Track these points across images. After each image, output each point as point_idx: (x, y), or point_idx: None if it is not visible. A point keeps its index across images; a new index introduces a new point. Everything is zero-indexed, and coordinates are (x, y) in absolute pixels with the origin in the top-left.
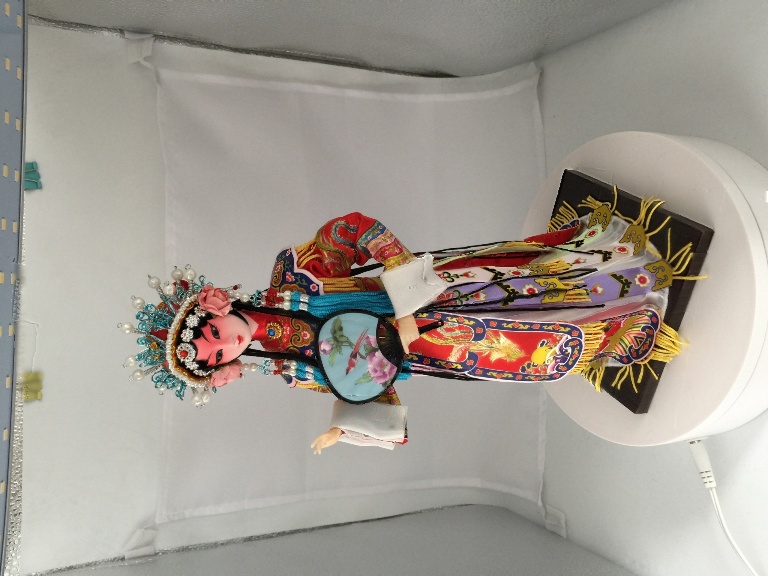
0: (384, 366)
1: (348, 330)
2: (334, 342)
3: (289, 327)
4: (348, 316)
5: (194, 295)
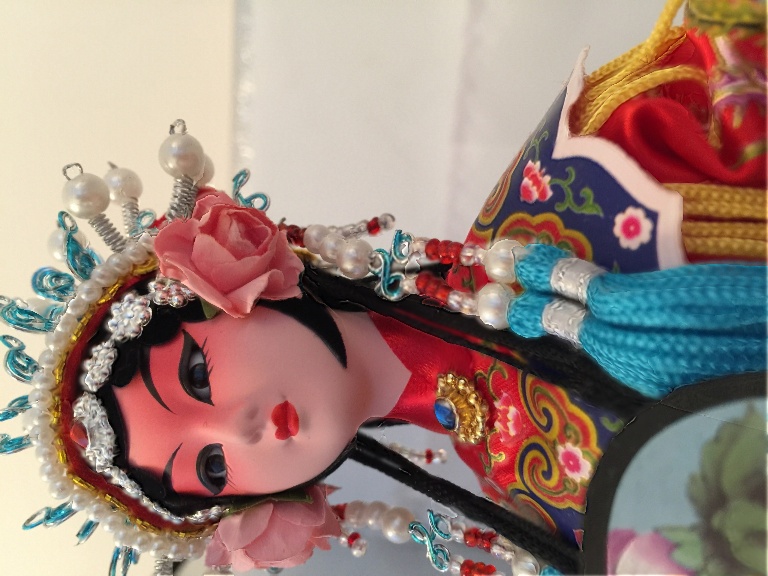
0: None
1: None
2: (706, 561)
3: (515, 406)
4: None
5: None
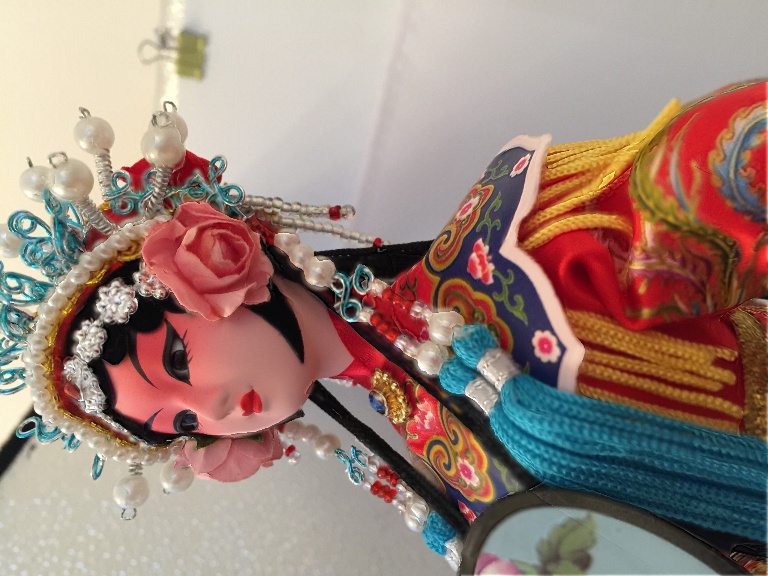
0: None
1: None
2: None
3: (432, 413)
4: (631, 535)
5: (160, 217)
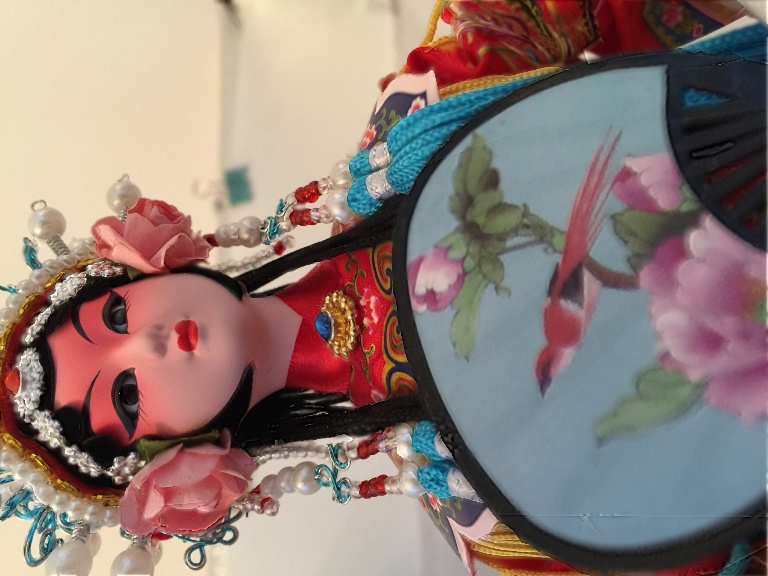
0: (767, 302)
1: (522, 174)
2: (467, 246)
3: (374, 295)
4: (516, 117)
5: None
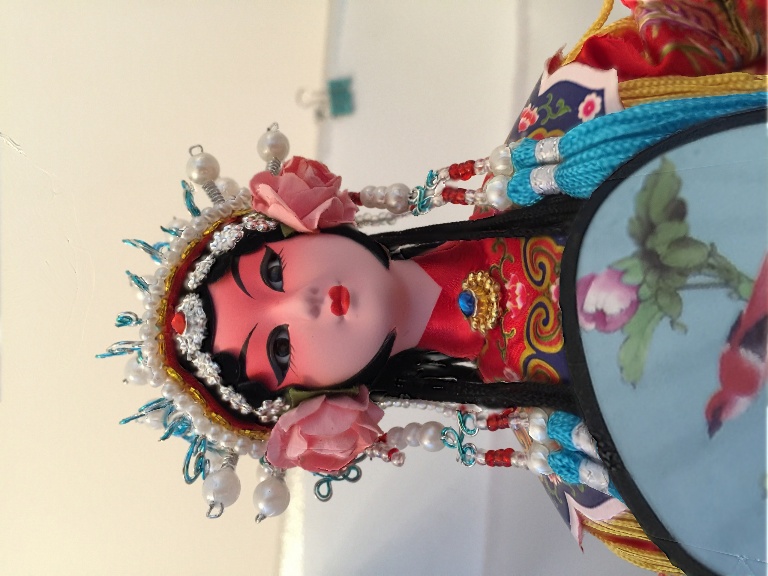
0: None
1: (713, 211)
2: (644, 274)
3: (521, 282)
4: (712, 148)
5: None
